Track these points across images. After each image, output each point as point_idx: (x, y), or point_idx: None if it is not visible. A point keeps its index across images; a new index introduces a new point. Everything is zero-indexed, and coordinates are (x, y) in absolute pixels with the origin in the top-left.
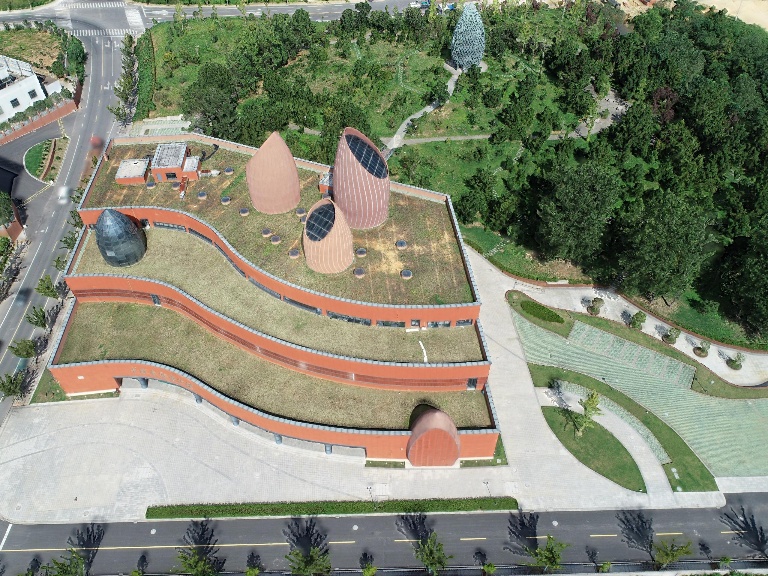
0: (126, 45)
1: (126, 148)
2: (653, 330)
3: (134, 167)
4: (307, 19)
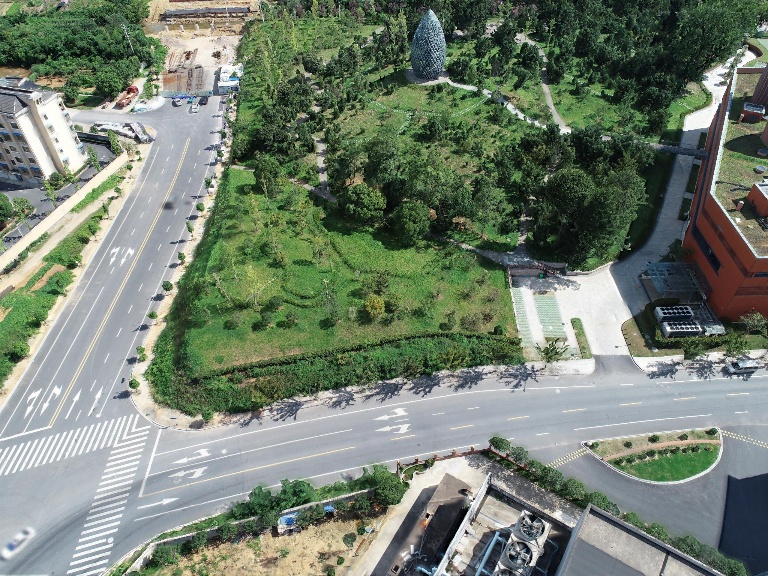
0: (304, 382)
1: (757, 250)
2: None
3: None
4: None
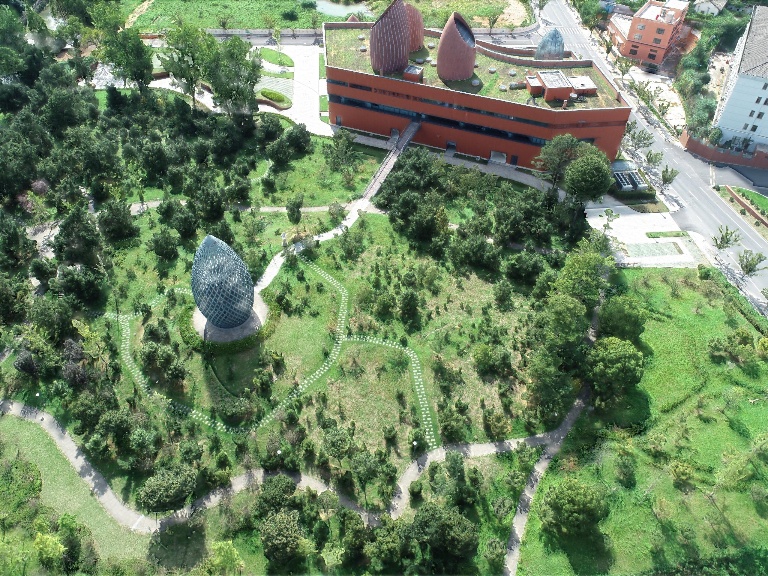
0: None
1: None
2: (206, 96)
3: (581, 83)
4: (559, 490)
